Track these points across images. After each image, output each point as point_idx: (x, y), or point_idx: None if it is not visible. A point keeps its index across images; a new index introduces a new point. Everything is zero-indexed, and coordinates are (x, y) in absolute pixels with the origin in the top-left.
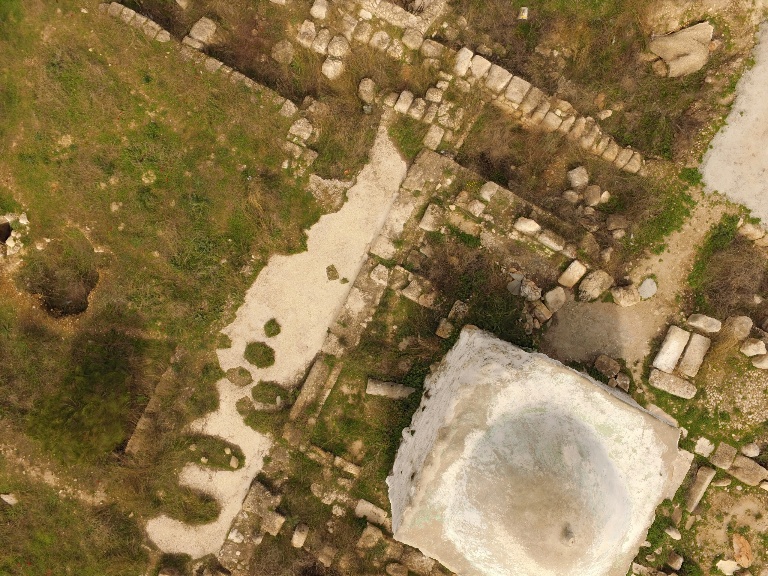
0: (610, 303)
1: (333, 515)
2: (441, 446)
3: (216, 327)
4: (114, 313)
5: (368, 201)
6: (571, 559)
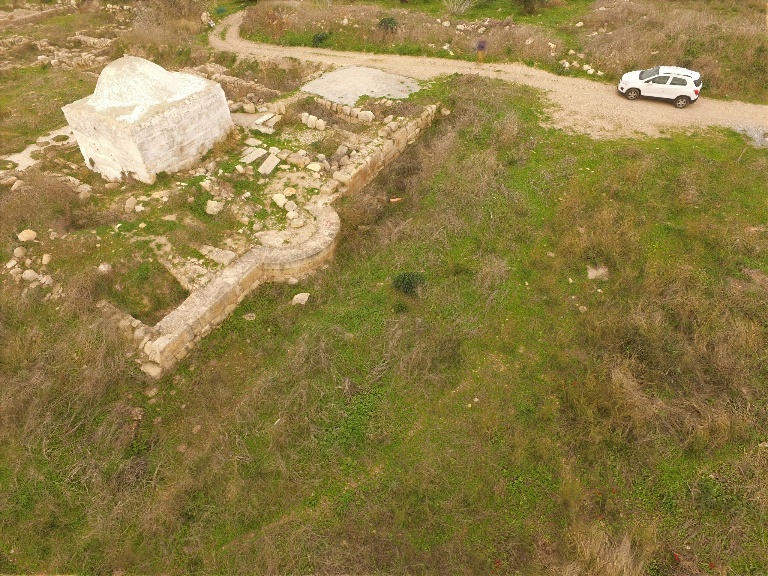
0: (243, 113)
1: None
2: None
3: (47, 131)
4: (0, 126)
5: None
6: None
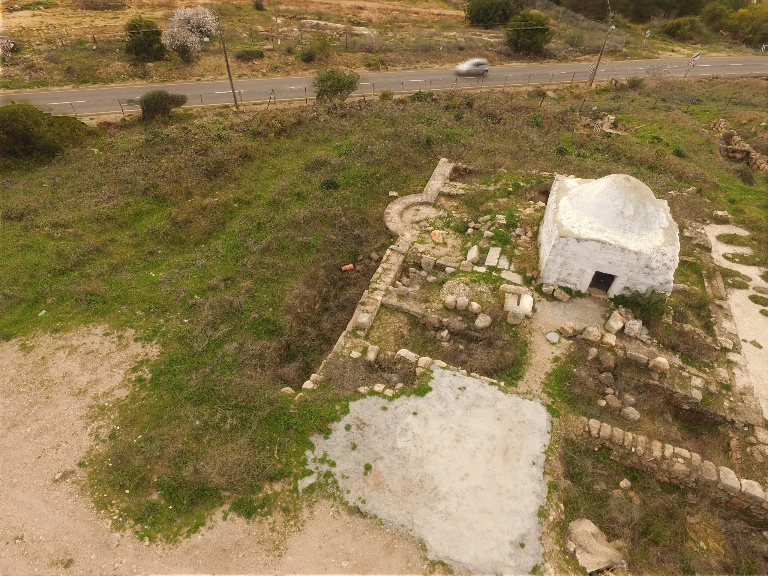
0: None
1: None
2: None
3: None
4: None
5: None
6: None
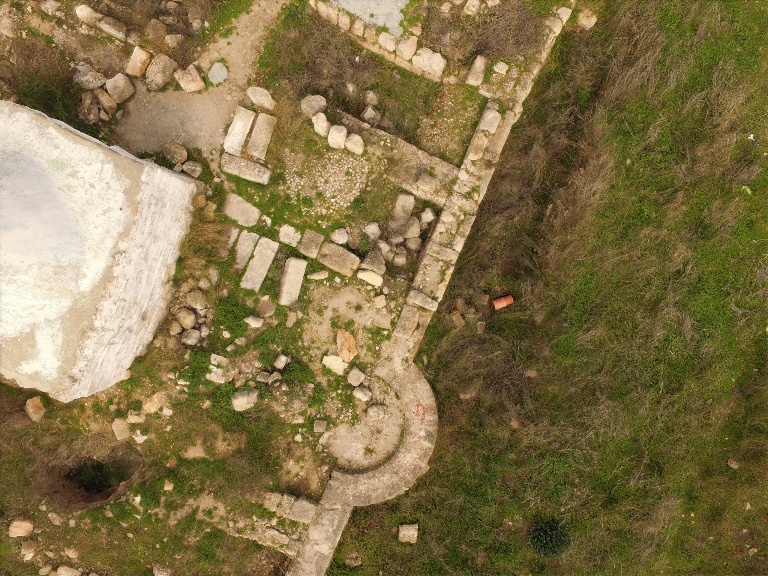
0: (183, 92)
1: None
2: None
3: None
4: None
5: None
6: None
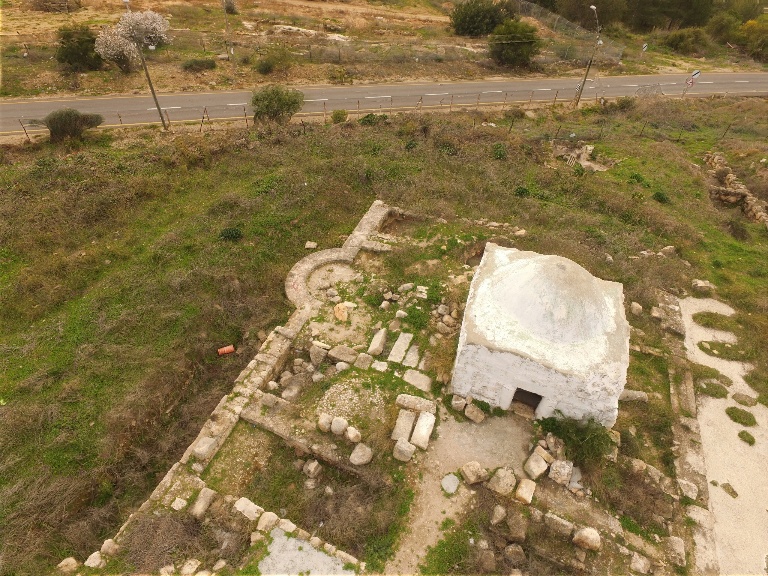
0: None
1: None
2: None
3: None
4: None
5: (744, 572)
6: (554, 259)
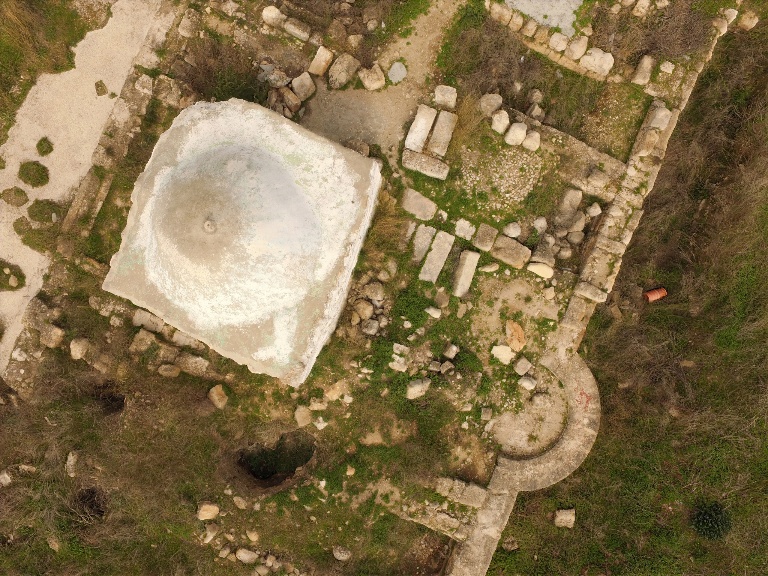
0: (362, 90)
1: (111, 326)
2: (136, 188)
3: None
4: None
5: (133, 15)
6: (215, 248)
